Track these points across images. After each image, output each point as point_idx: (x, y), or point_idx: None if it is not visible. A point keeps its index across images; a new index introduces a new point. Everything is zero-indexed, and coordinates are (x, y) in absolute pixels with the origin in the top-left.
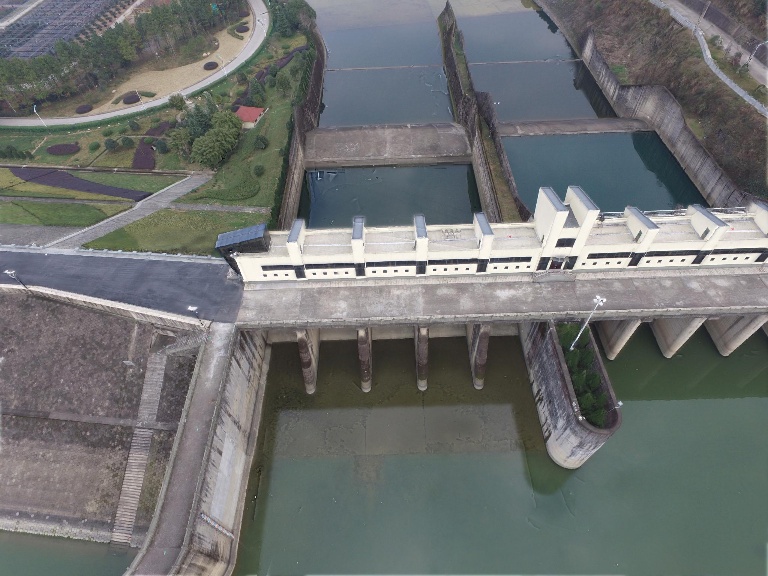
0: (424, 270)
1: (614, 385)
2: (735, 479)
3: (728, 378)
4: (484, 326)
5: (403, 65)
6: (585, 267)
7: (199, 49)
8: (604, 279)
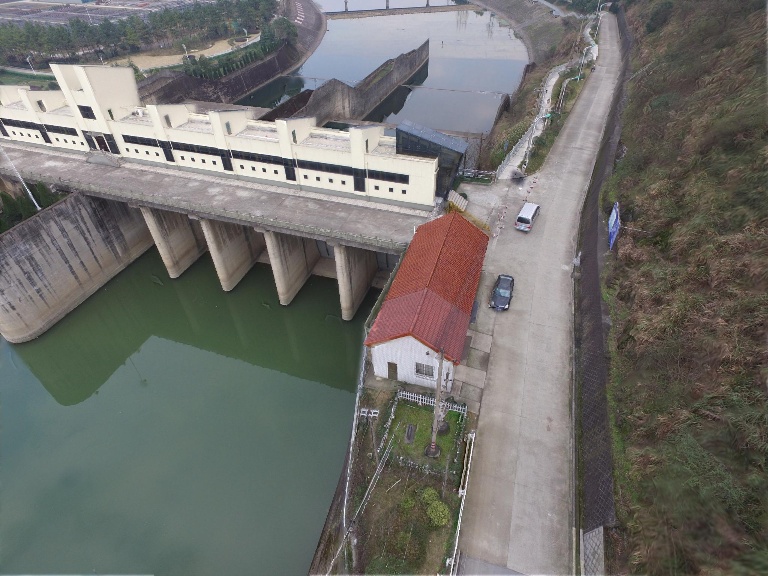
0: (6, 131)
1: (216, 330)
2: (142, 405)
3: (329, 355)
4: (12, 184)
5: (347, 79)
6: (132, 155)
7: (194, 47)
8: (146, 171)
